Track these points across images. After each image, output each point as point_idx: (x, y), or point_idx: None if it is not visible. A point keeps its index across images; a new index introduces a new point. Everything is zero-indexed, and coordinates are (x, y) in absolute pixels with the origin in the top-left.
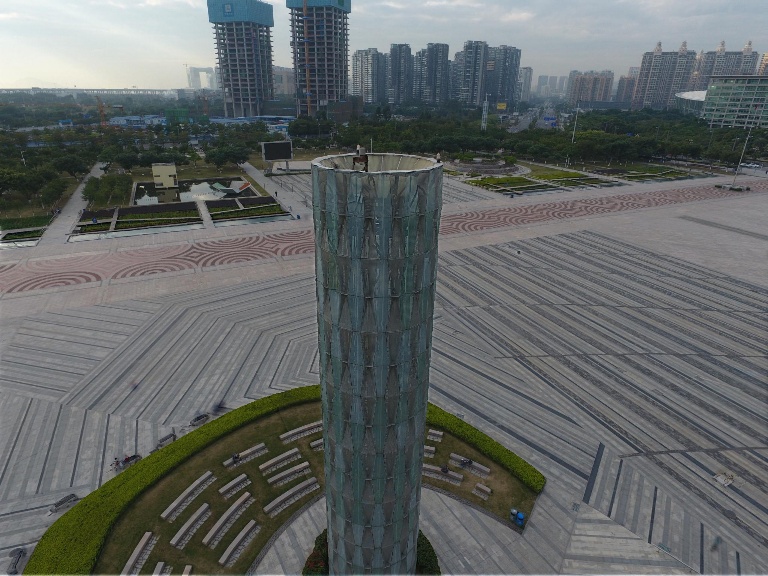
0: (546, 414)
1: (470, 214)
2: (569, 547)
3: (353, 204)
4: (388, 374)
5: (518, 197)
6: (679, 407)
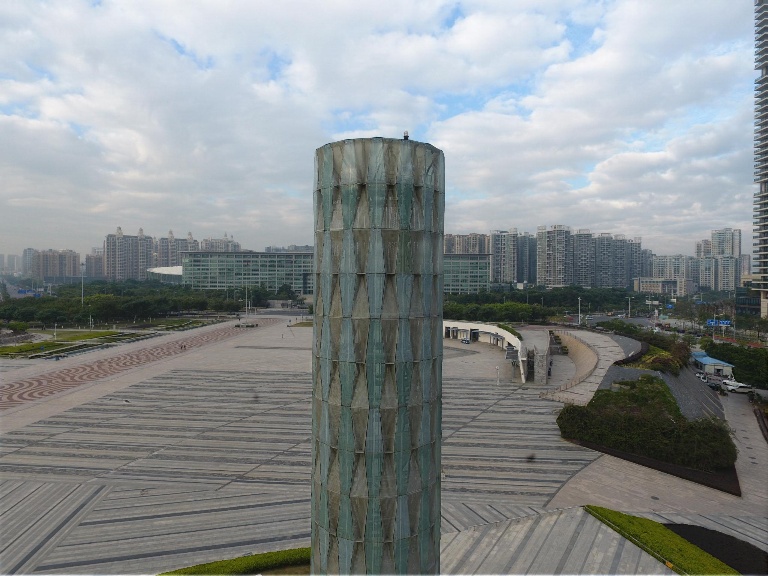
0: None
1: (17, 384)
2: None
3: (423, 176)
4: None
5: (65, 359)
6: None
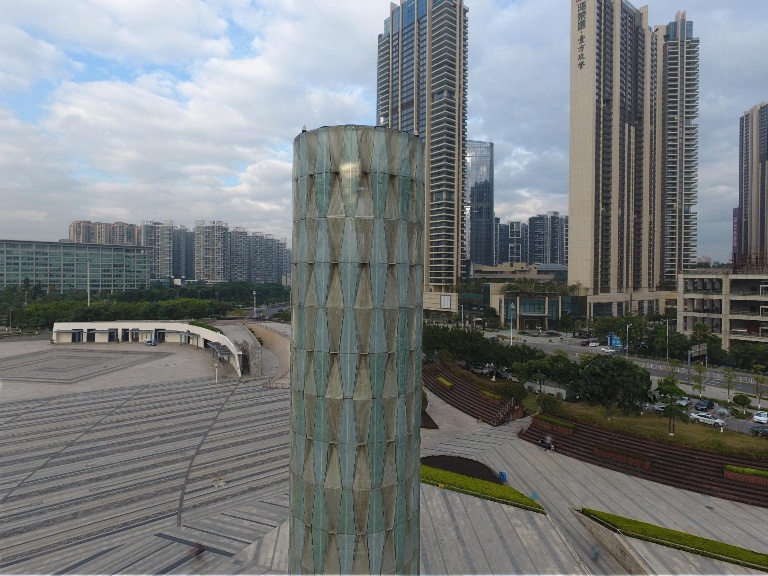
0: (82, 571)
1: None
2: (285, 571)
3: None
4: None
5: None
6: (124, 483)
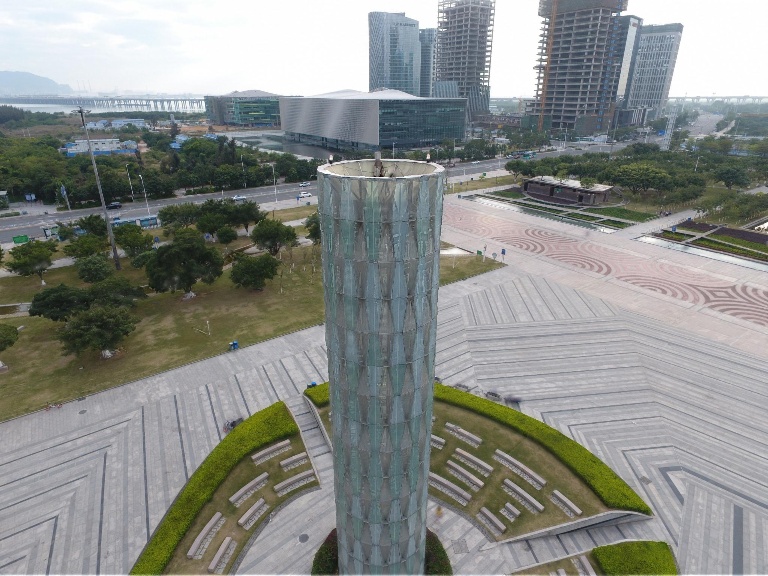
0: None
1: None
2: None
3: None
4: (329, 355)
5: None
6: None
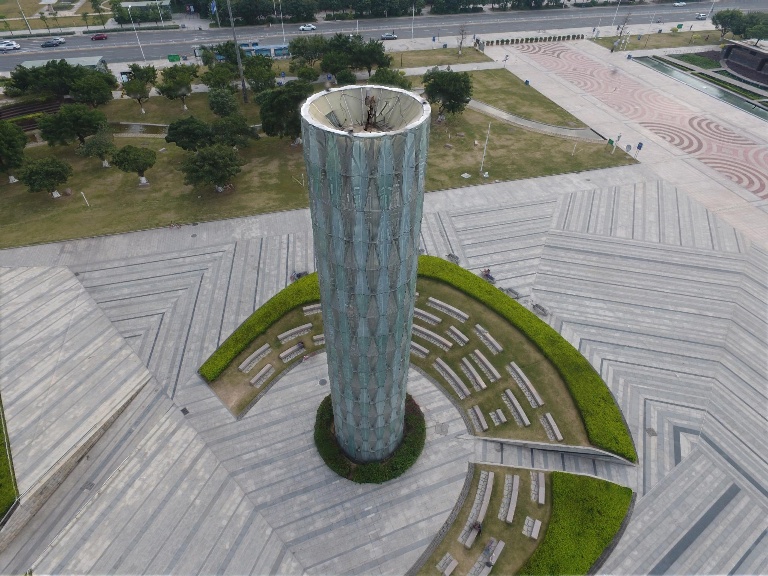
0: None
1: None
2: None
3: None
4: None
5: None
6: None
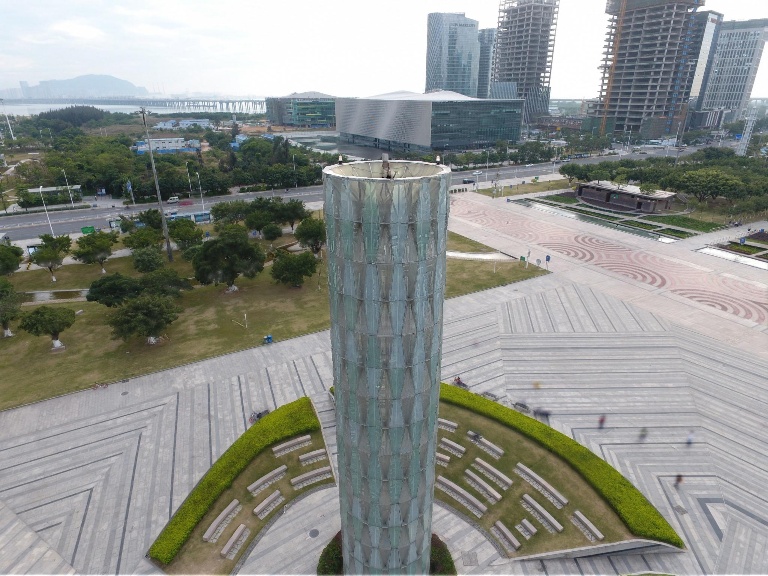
0: None
1: None
2: None
3: None
4: None
5: None
6: None
